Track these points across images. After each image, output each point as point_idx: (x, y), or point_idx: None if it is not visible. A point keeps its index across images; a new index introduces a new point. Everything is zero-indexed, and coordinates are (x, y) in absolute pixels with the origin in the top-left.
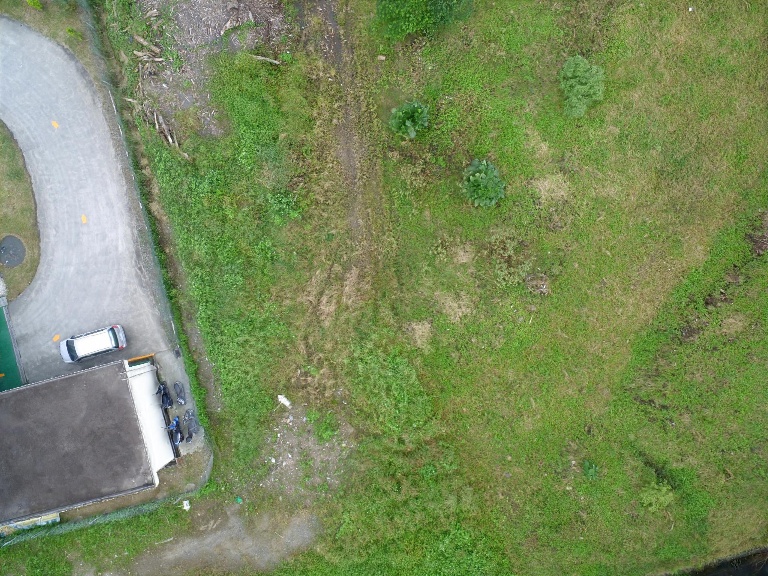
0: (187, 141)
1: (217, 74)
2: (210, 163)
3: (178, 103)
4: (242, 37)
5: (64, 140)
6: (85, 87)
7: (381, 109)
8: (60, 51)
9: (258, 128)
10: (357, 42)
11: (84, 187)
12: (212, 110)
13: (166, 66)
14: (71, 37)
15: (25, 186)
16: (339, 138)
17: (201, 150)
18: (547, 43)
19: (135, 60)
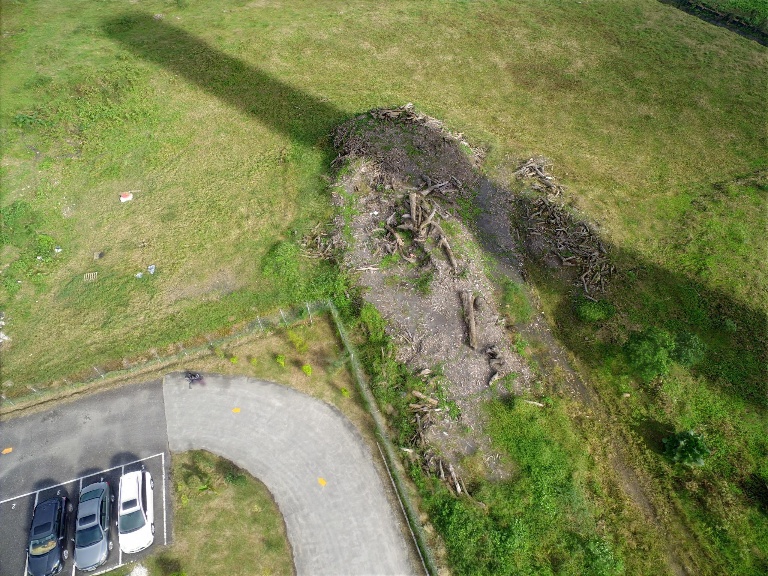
0: (483, 488)
1: (494, 419)
2: (510, 511)
3: (461, 449)
4: (510, 386)
5: (332, 499)
6: (353, 441)
7: (647, 440)
8: (326, 409)
9: (550, 468)
10: (597, 384)
11: (358, 555)
12: (496, 453)
13: (444, 415)
14: (337, 396)
15: (285, 561)
16: (619, 472)
17: (498, 497)
18: (762, 374)
19: (409, 412)
